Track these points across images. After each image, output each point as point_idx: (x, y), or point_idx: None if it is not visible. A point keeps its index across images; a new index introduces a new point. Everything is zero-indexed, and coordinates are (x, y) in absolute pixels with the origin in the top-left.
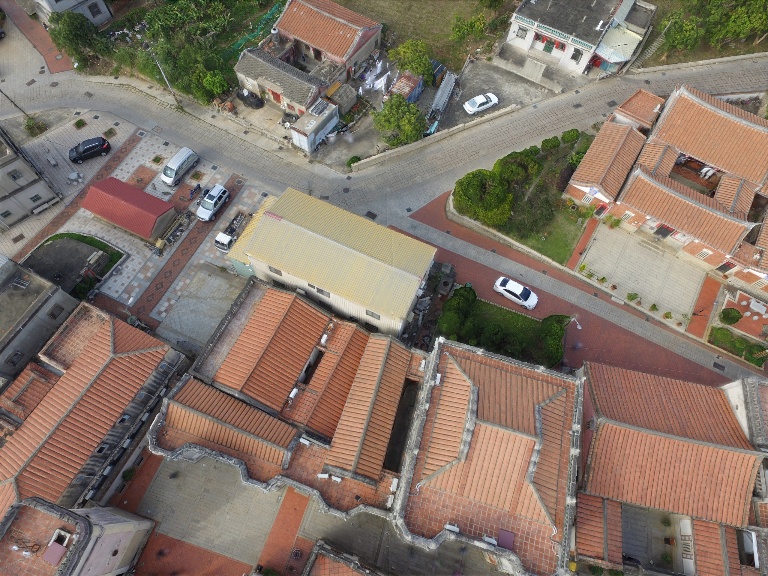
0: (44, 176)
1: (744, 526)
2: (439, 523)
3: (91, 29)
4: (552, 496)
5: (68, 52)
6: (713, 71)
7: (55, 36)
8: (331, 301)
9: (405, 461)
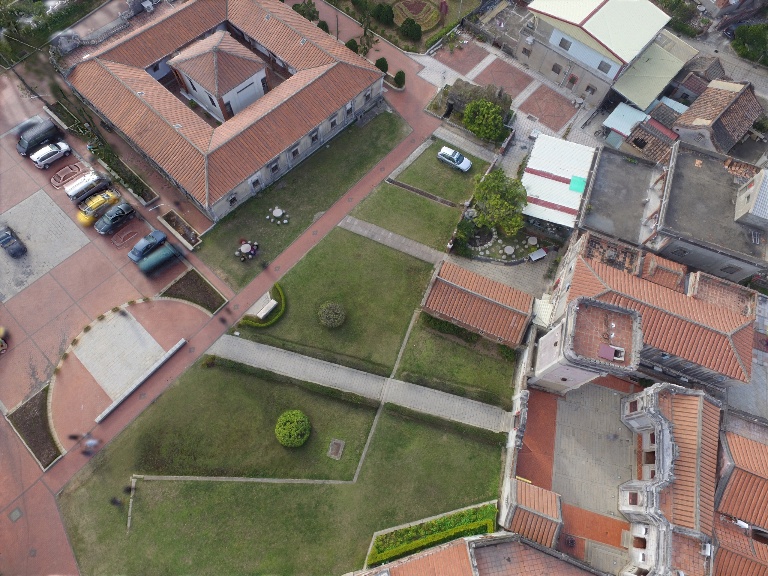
0: None
1: None
2: None
3: None
4: None
5: None
6: None
7: None
8: None
9: None
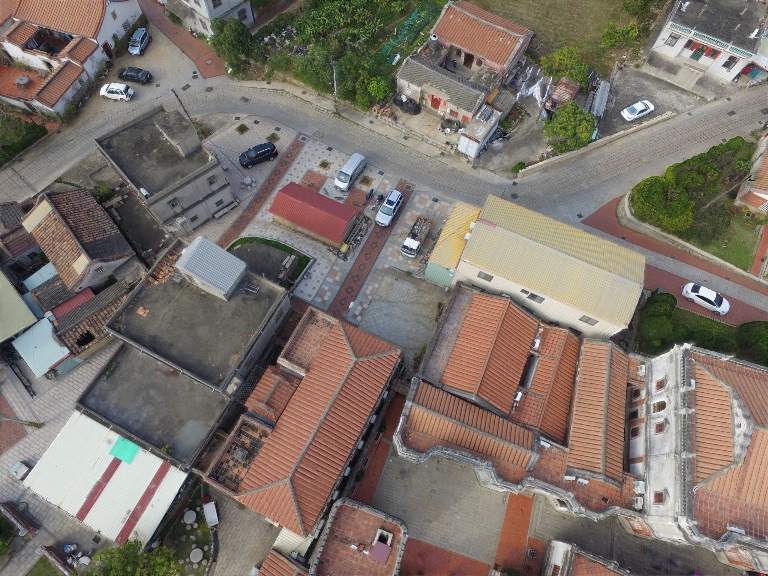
0: None
1: None
2: (720, 525)
3: (247, 35)
4: None
5: (227, 58)
6: None
7: (218, 42)
8: (539, 306)
9: (648, 464)
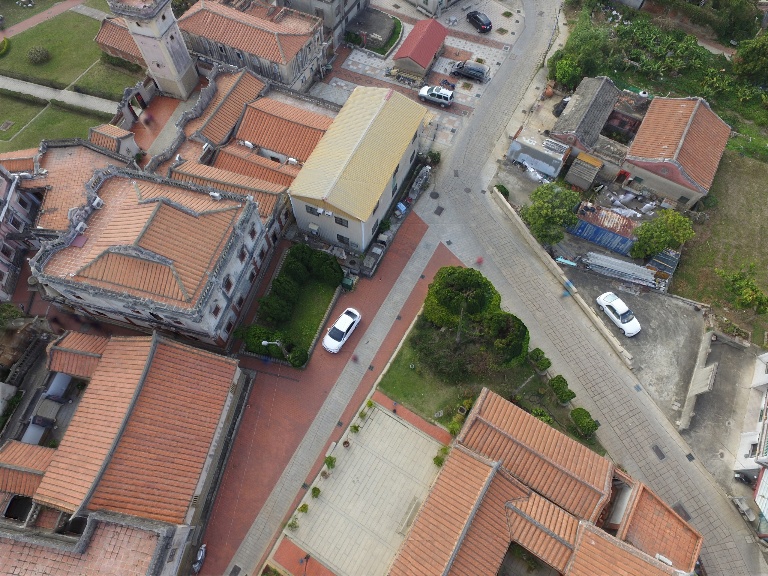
0: (452, 7)
1: (35, 495)
2: (106, 198)
3: None
4: (98, 274)
5: None
6: None
7: None
8: None
9: None
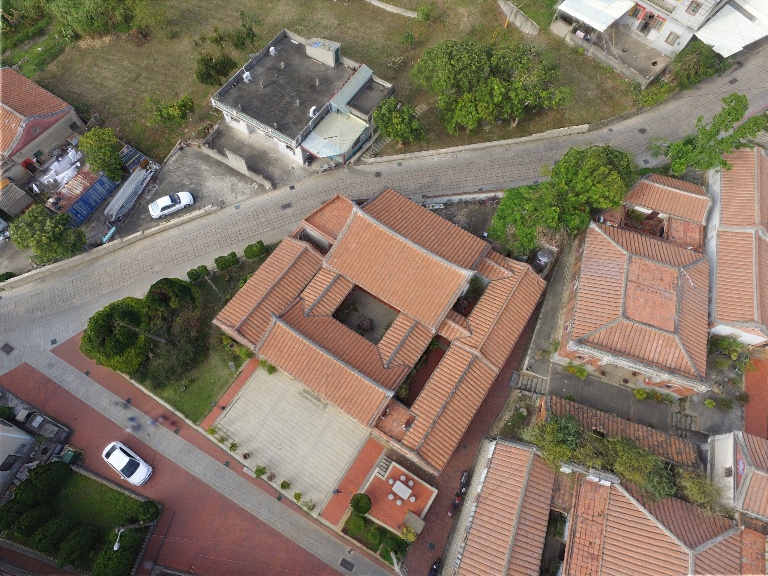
0: None
1: None
2: None
3: None
4: None
5: None
6: (457, 161)
7: None
8: None
9: None
